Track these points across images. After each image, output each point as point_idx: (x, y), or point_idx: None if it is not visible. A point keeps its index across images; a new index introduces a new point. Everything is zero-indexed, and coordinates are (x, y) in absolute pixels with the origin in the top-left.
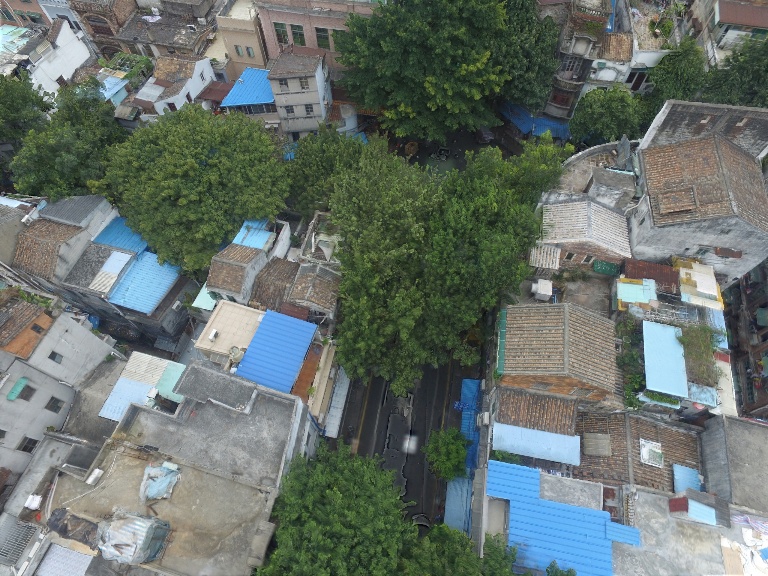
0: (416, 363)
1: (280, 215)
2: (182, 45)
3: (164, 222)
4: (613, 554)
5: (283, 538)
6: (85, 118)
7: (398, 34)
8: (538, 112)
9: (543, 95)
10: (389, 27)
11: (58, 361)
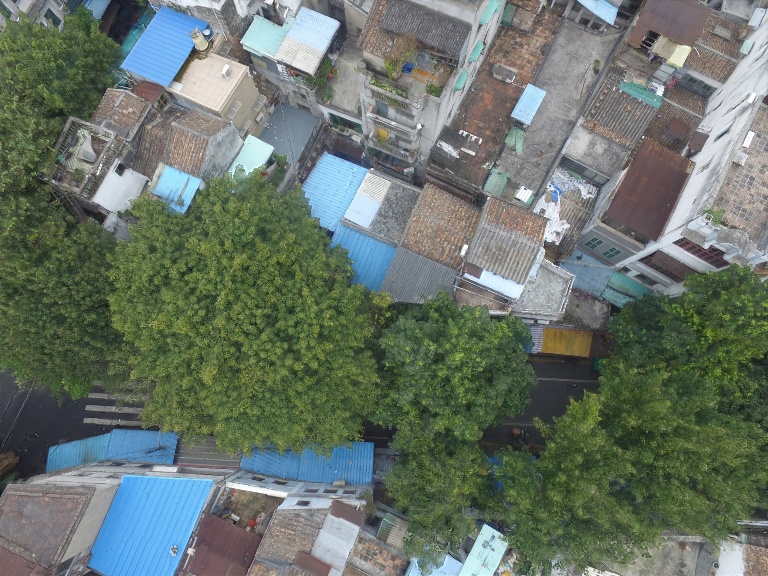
0: None
1: None
2: None
3: None
4: None
5: None
6: None
7: None
8: None
9: None
10: None
11: None
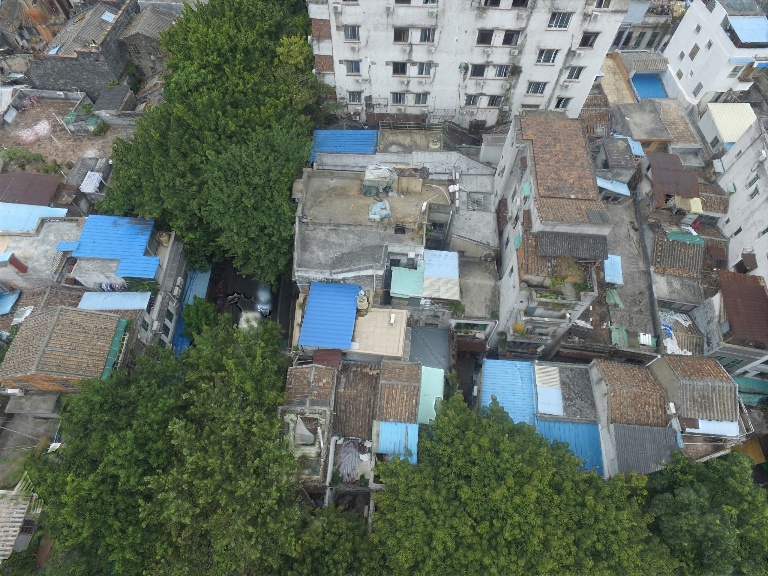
0: None
1: None
2: None
3: None
4: None
5: None
6: None
7: None
8: None
9: None
10: None
11: (510, 273)
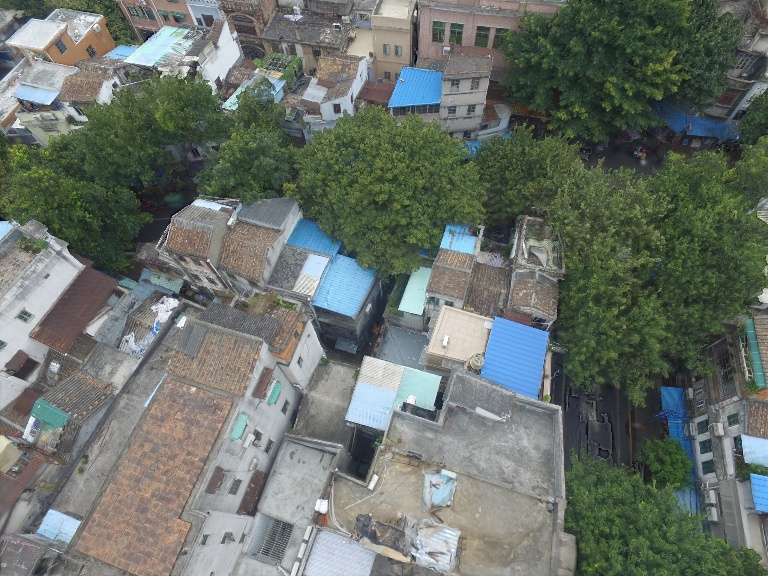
0: (649, 372)
1: None
2: (329, 44)
3: (365, 226)
4: None
5: (614, 552)
6: (261, 120)
7: (592, 34)
8: (693, 111)
9: (719, 94)
10: (580, 26)
11: (300, 365)
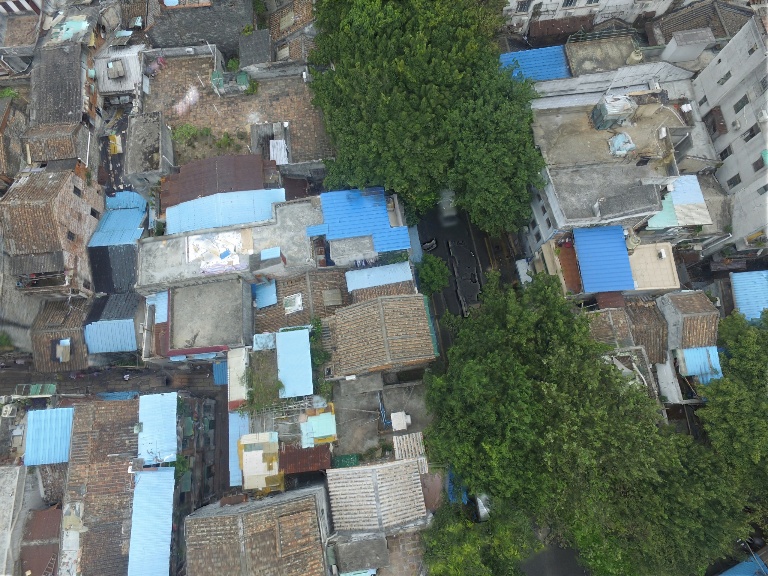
0: None
1: (698, 436)
2: None
3: None
4: (320, 223)
5: None
6: None
7: None
8: None
9: None
10: None
11: (760, 190)
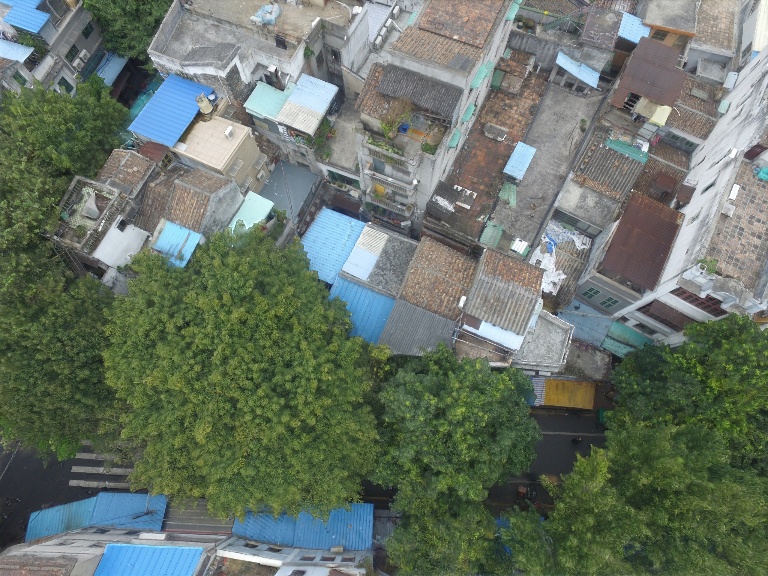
0: None
1: None
2: None
3: None
4: None
5: None
6: None
7: None
8: None
9: None
10: None
11: None
